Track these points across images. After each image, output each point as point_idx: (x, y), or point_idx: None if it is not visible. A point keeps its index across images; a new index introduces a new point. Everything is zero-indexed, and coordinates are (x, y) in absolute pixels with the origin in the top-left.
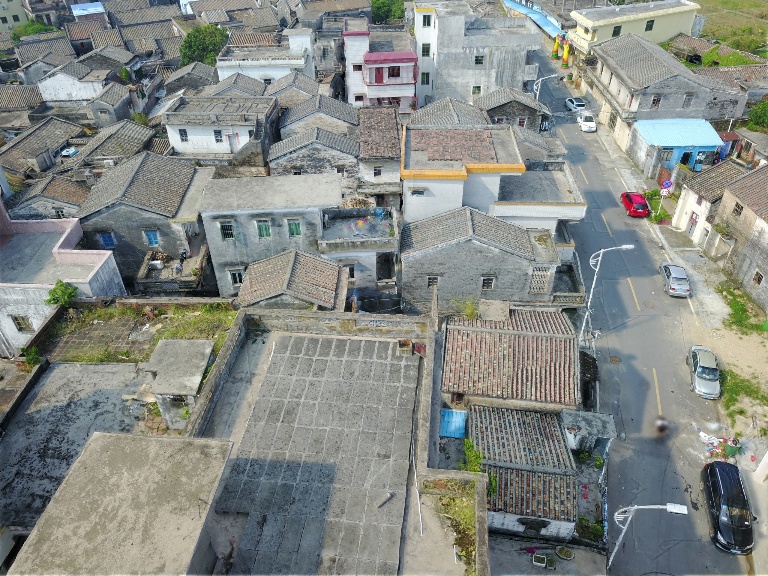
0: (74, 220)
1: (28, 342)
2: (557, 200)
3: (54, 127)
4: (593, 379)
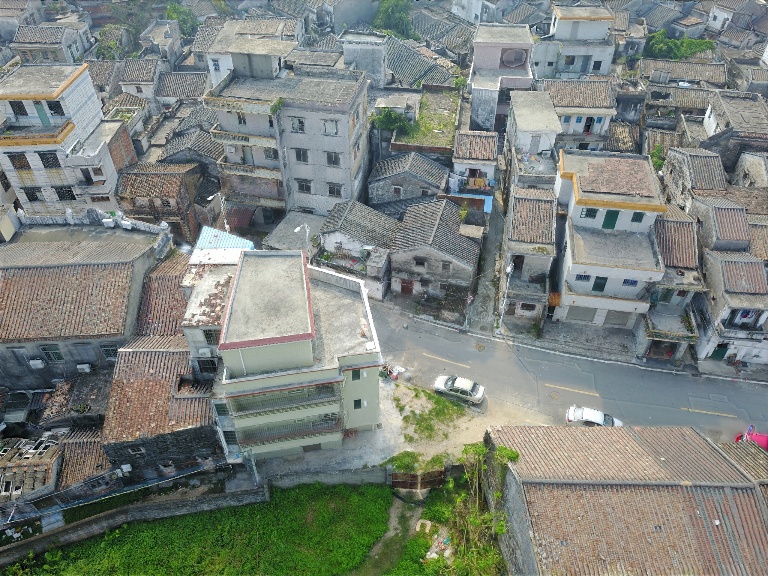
0: (531, 77)
1: (431, 84)
2: (595, 260)
3: (713, 70)
4: (442, 306)
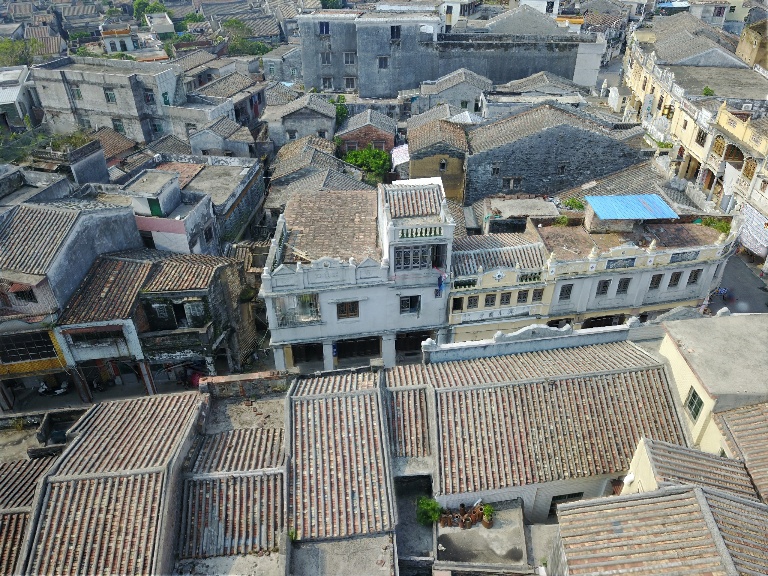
0: None
1: None
2: None
3: None
4: None
